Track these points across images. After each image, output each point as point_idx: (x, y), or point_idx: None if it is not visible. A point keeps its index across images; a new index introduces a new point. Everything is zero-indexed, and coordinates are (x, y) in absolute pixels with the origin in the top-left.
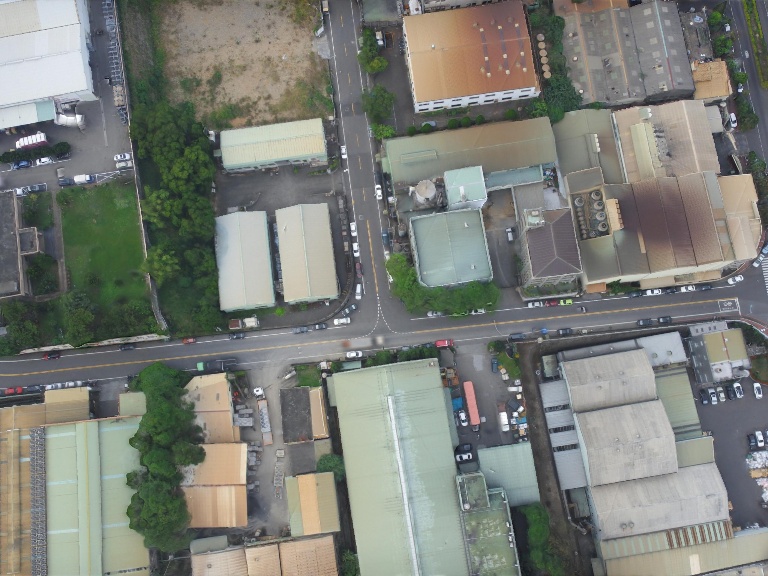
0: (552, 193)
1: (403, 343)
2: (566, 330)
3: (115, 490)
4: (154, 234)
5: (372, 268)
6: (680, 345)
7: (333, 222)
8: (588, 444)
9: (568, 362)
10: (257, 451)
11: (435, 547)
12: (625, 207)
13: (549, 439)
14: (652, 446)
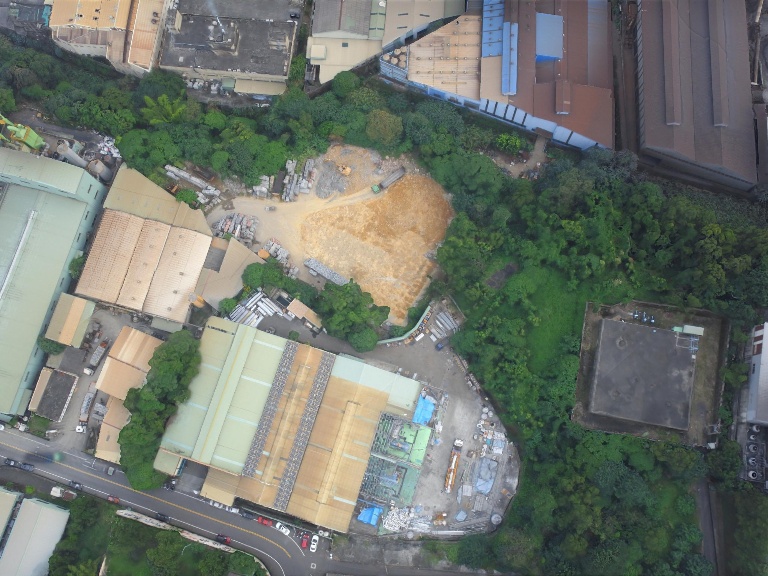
0: None
1: None
2: None
3: (204, 396)
4: None
5: None
6: None
7: None
8: None
9: None
10: None
11: (3, 252)
12: None
13: None
14: None
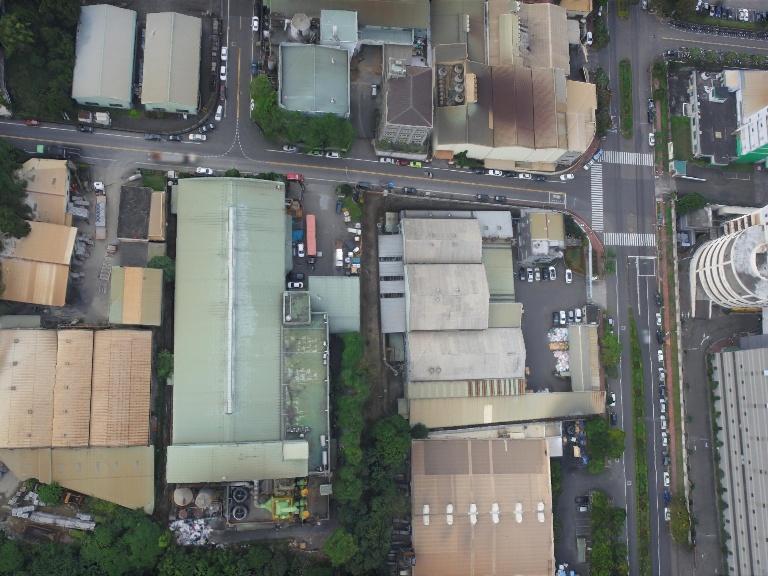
0: (420, 62)
1: (255, 170)
2: (411, 189)
3: None
4: (11, 6)
5: (236, 94)
6: (510, 223)
7: (205, 41)
8: (412, 290)
9: (408, 219)
10: (87, 243)
11: (252, 354)
12: (482, 84)
13: (379, 286)
14: (468, 301)
